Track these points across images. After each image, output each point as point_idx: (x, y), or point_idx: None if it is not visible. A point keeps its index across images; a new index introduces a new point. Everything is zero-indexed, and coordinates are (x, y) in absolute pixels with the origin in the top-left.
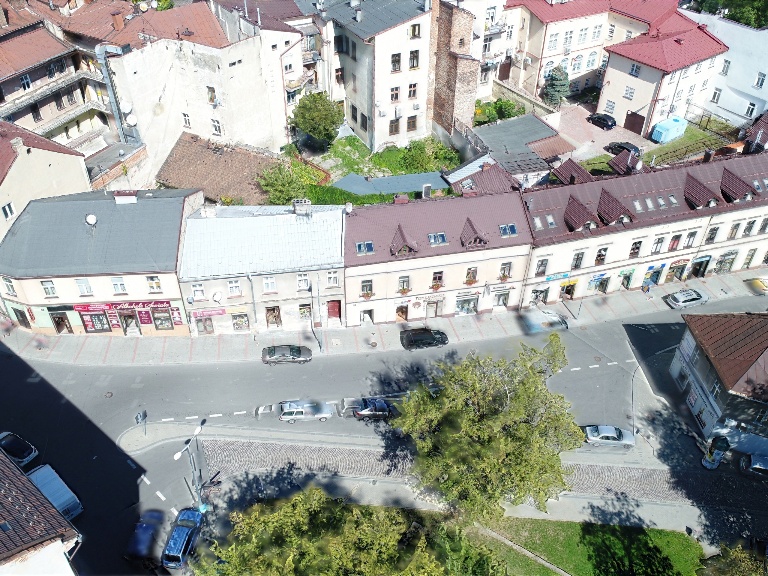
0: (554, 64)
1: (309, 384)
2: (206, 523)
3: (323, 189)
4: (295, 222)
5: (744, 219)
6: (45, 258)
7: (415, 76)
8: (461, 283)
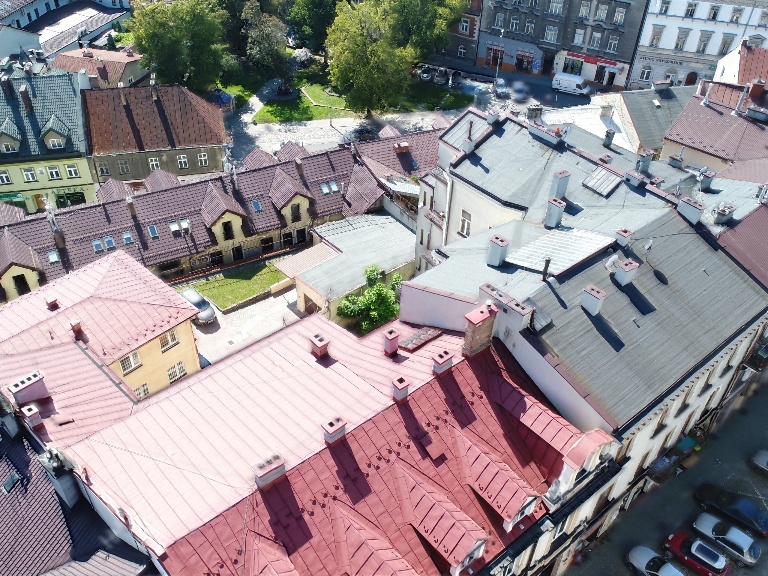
0: None
1: None
2: (496, 96)
3: None
4: None
5: None
6: None
7: None
8: None
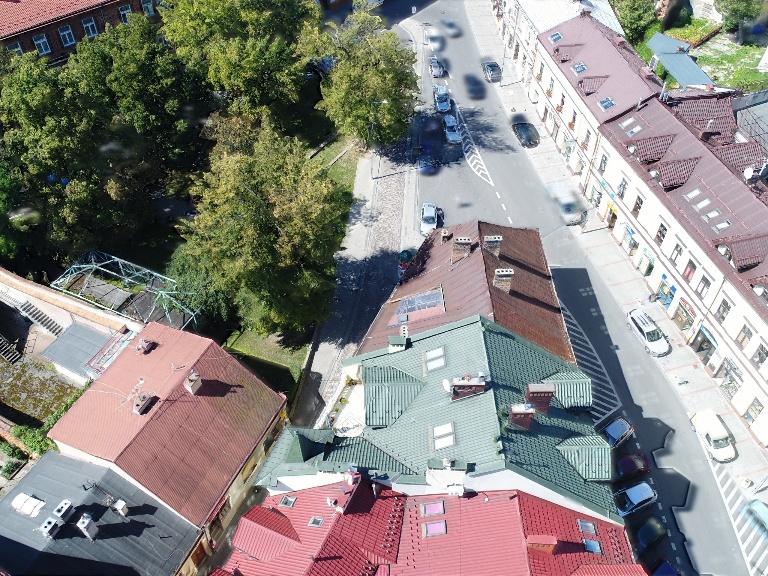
0: None
1: (466, 82)
2: None
3: None
4: None
5: (755, 329)
6: None
7: None
8: None
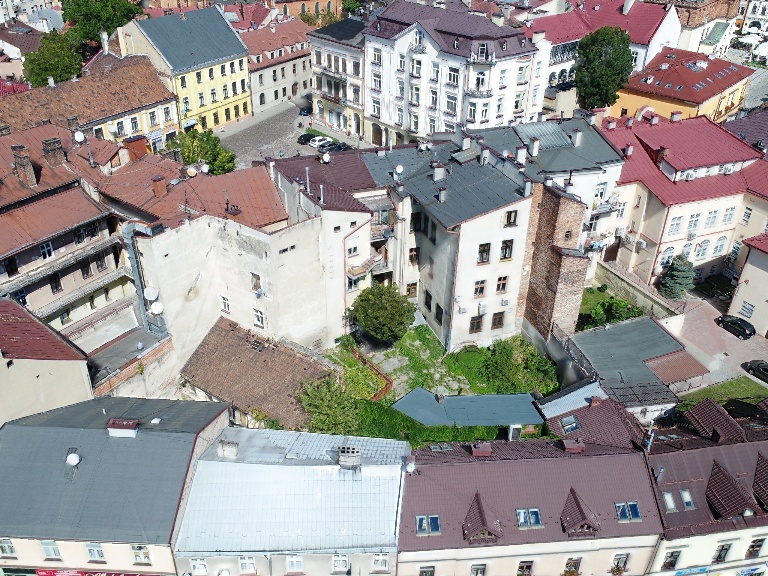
0: (674, 250)
1: None
2: None
3: (381, 409)
4: (337, 477)
5: None
6: (5, 508)
7: (506, 268)
8: (557, 575)
